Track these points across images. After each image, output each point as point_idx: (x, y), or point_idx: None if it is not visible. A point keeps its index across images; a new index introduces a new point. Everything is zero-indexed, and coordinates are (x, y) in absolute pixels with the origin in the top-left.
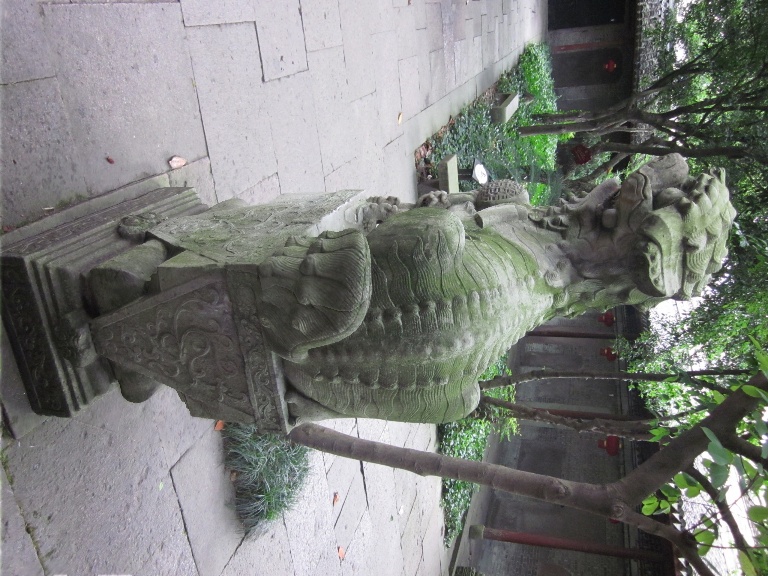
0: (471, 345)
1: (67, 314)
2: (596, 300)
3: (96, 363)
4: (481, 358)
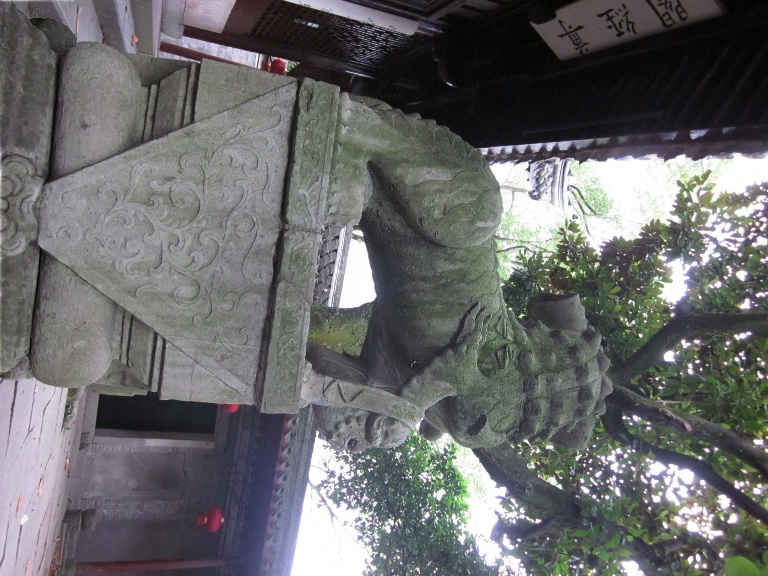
0: None
1: None
2: None
3: (52, 46)
4: None
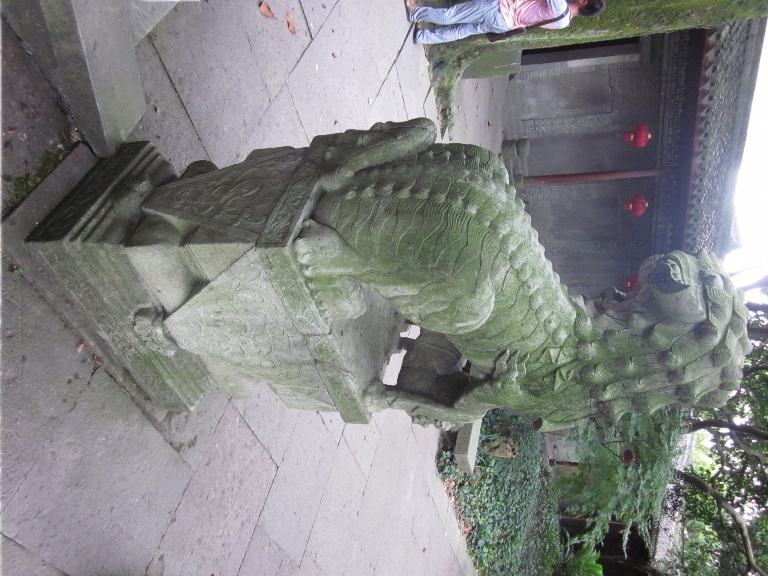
0: (503, 200)
1: None
2: (620, 336)
3: (126, 221)
4: (507, 234)
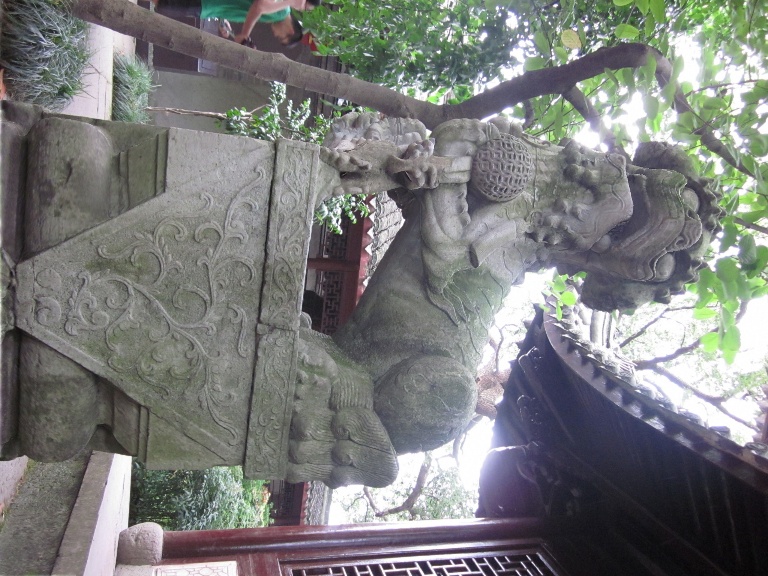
0: None
1: (2, 457)
2: None
3: None
4: None
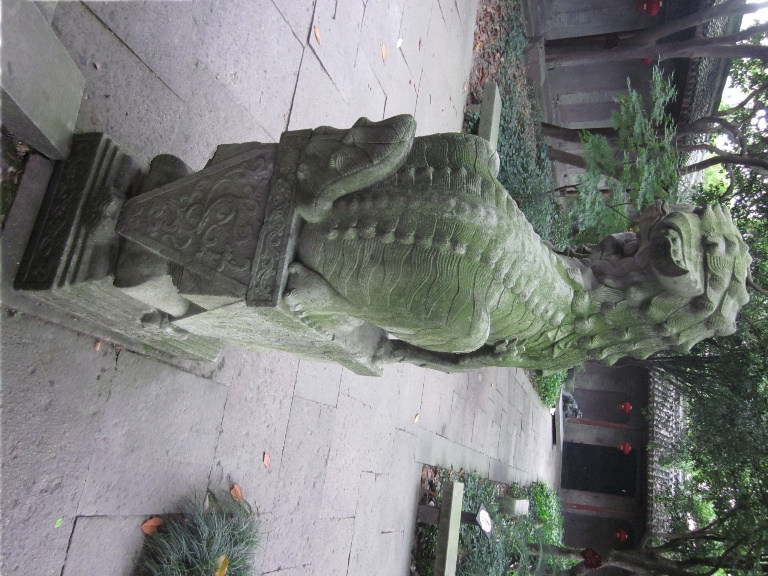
0: (494, 224)
1: None
2: (617, 310)
3: (106, 247)
4: (500, 258)
